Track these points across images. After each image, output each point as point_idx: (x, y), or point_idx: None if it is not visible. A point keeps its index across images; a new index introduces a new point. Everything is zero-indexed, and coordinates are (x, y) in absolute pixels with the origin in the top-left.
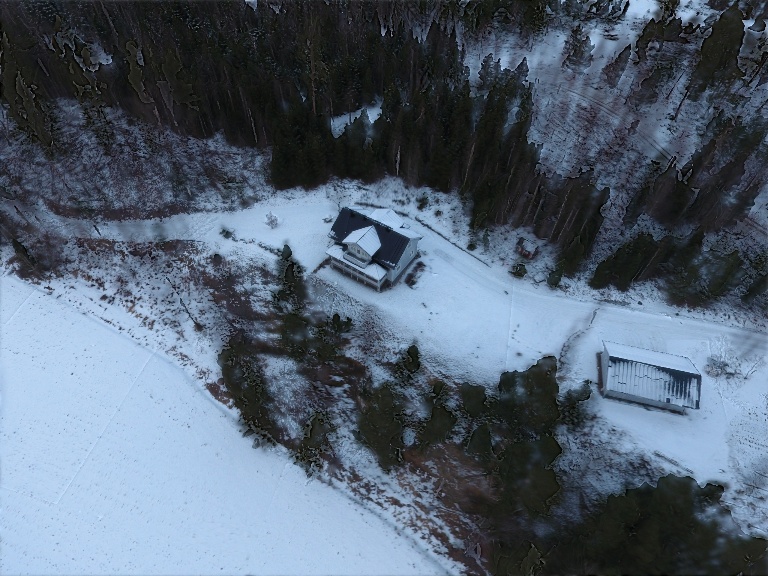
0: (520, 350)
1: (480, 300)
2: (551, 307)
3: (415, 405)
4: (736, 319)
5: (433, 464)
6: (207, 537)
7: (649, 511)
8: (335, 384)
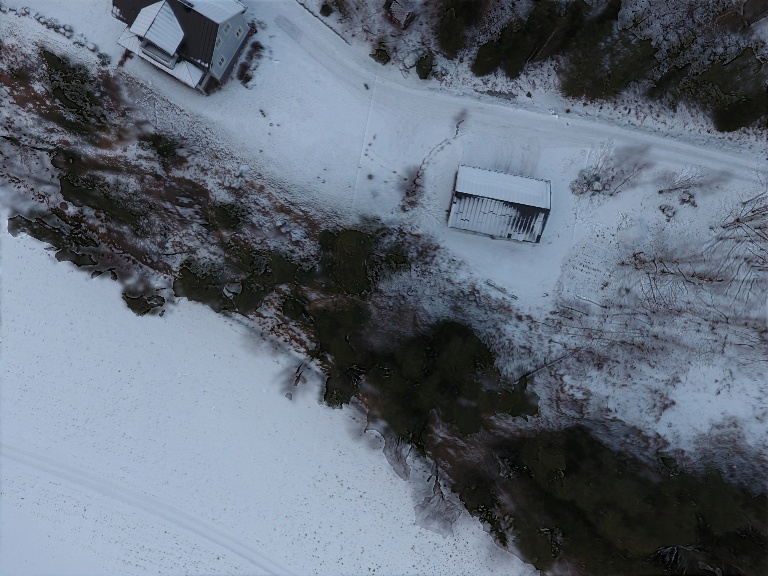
0: (372, 171)
1: (332, 101)
2: (418, 107)
3: (264, 233)
4: (636, 114)
5: (286, 287)
6: (100, 349)
7: (437, 366)
8: (184, 205)
